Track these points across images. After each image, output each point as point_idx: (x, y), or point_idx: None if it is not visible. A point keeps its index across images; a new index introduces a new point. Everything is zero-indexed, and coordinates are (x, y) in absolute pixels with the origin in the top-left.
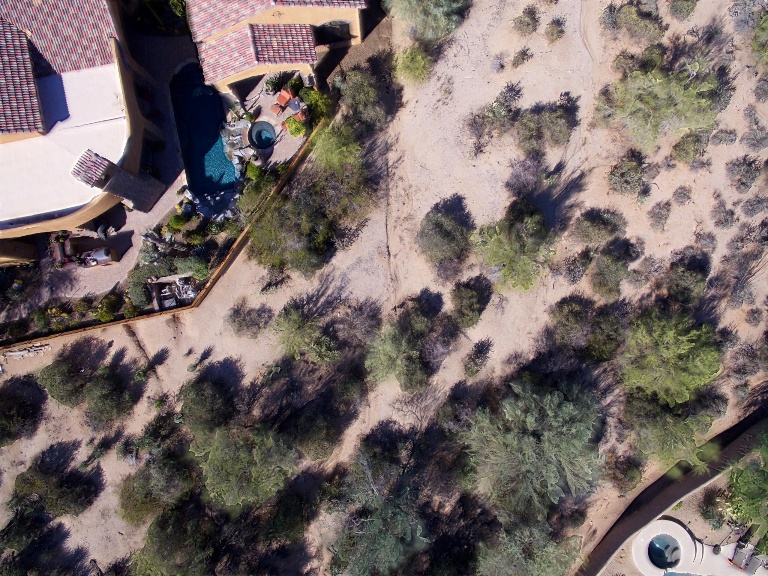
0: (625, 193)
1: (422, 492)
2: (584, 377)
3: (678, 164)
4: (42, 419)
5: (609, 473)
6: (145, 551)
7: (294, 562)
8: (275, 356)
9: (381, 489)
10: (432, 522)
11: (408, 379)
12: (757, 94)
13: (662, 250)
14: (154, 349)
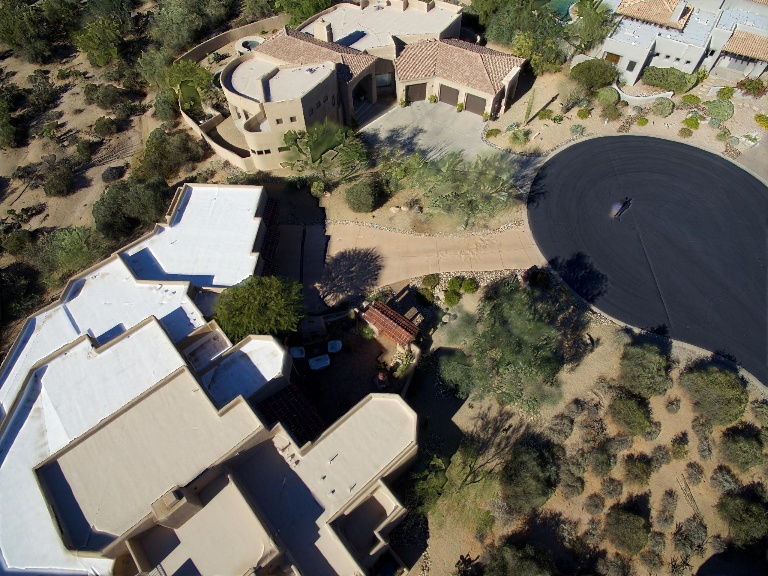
0: None
1: (144, 33)
2: (236, 4)
3: None
4: None
5: None
6: None
7: (67, 52)
8: None
9: None
10: (143, 41)
11: None
12: None
13: None
14: None
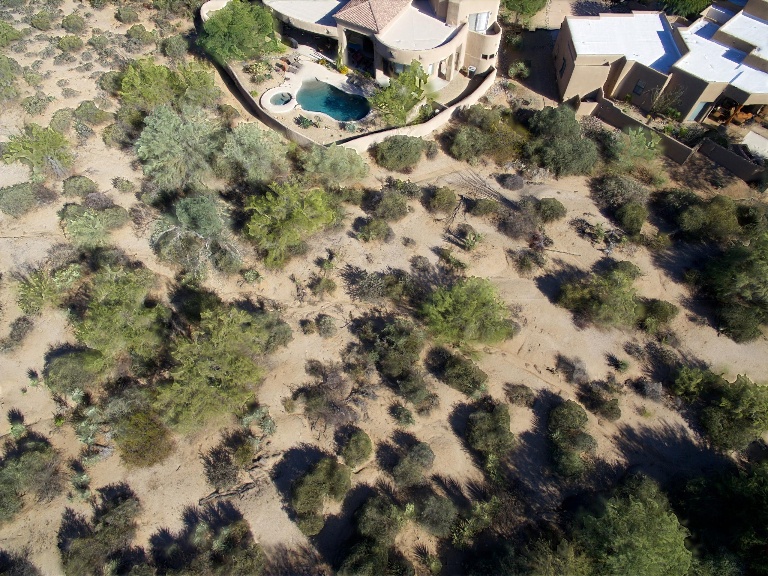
0: (47, 107)
1: None
2: None
3: (42, 84)
4: (26, 560)
5: (224, 121)
6: (168, 408)
7: None
8: (63, 319)
9: (179, 230)
10: (238, 218)
11: (111, 218)
12: (19, 51)
13: (93, 93)
14: (4, 424)
